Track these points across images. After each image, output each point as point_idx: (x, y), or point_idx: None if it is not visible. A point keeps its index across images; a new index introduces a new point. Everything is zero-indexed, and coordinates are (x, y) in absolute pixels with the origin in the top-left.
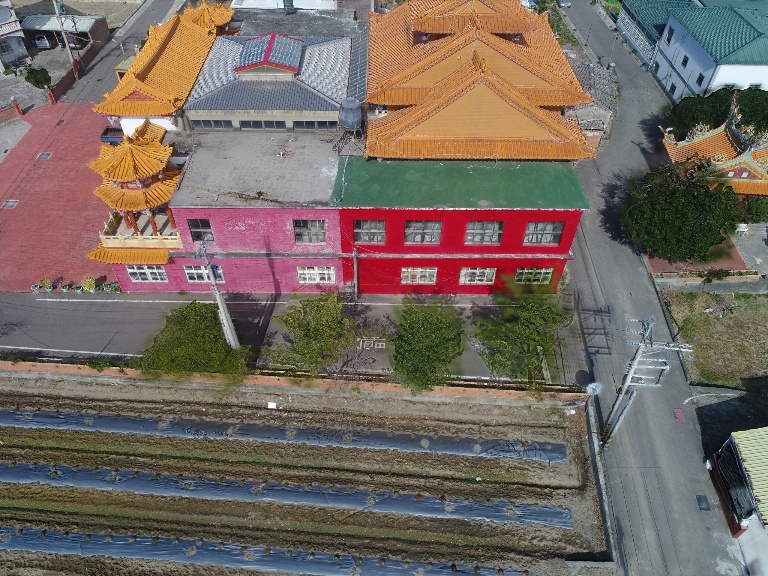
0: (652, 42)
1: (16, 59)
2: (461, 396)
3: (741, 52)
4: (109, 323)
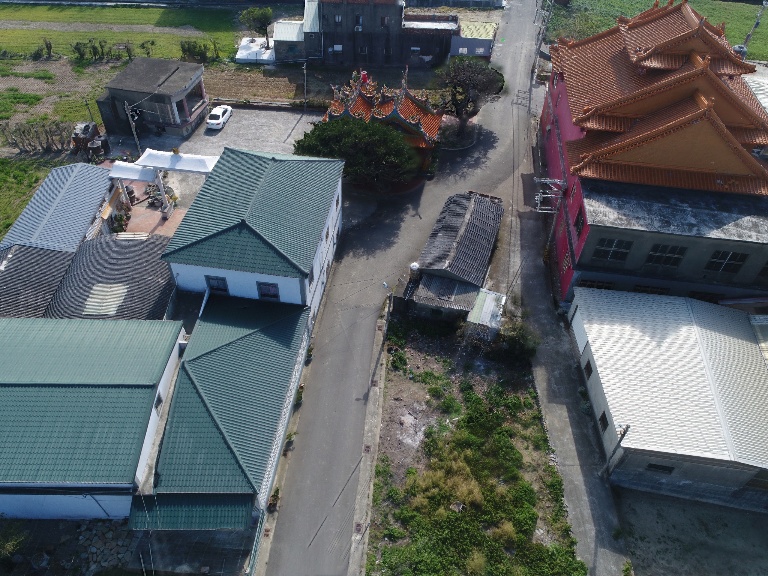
0: None
1: None
2: None
3: None
4: None
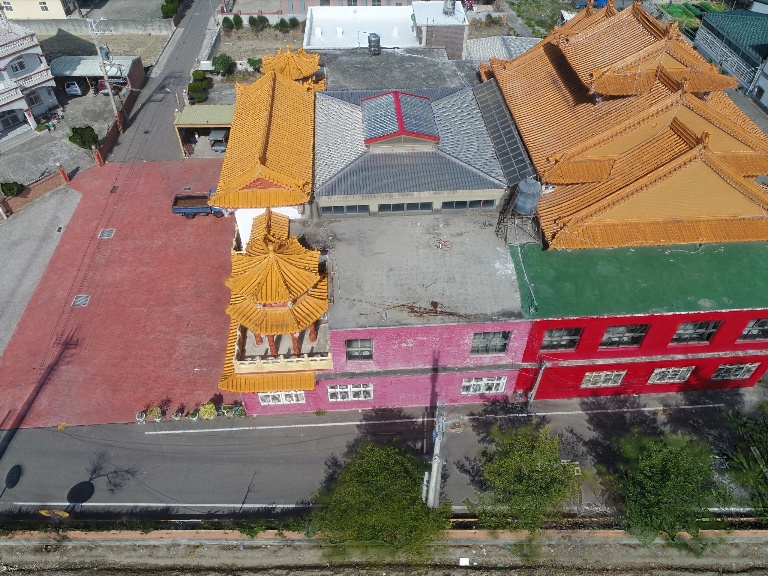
0: (751, 65)
1: (47, 111)
2: (693, 537)
3: None
4: (242, 461)
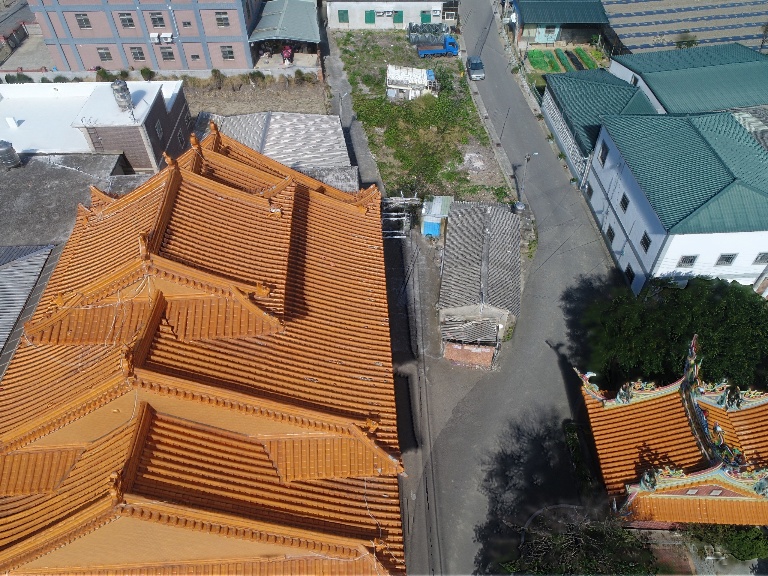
0: (583, 152)
1: None
2: None
3: (705, 212)
4: None
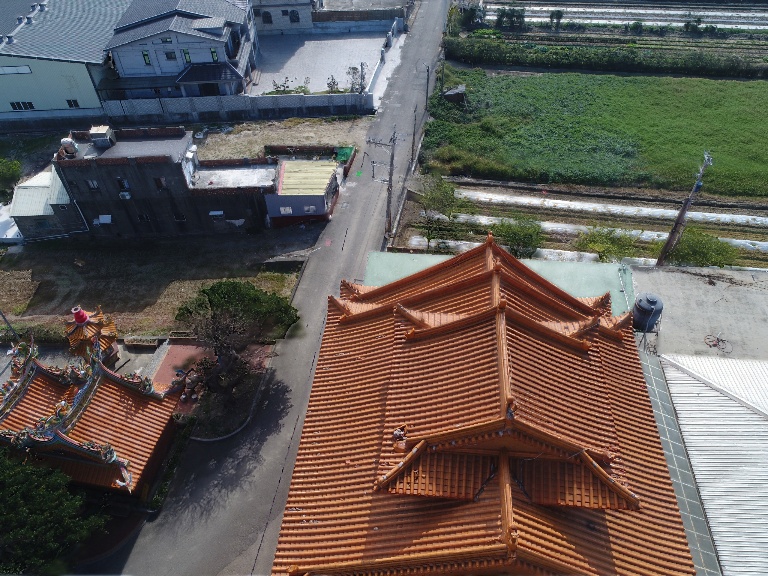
0: None
1: None
2: None
3: None
4: None
